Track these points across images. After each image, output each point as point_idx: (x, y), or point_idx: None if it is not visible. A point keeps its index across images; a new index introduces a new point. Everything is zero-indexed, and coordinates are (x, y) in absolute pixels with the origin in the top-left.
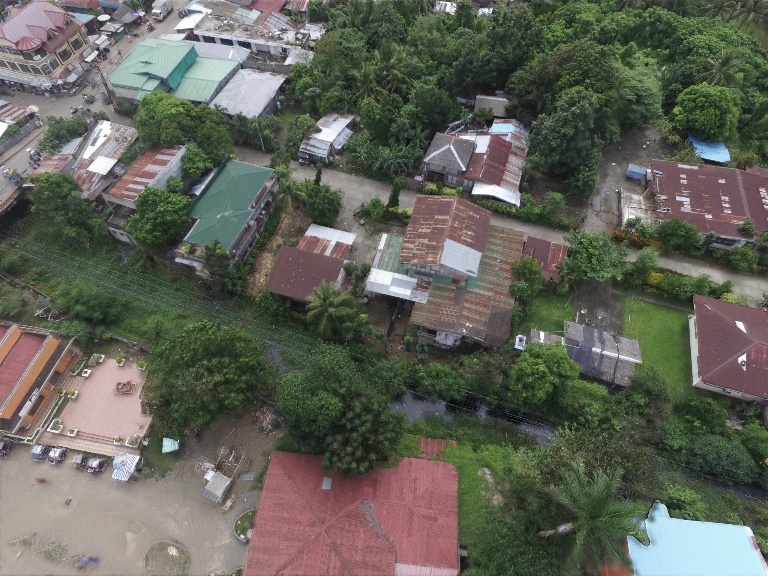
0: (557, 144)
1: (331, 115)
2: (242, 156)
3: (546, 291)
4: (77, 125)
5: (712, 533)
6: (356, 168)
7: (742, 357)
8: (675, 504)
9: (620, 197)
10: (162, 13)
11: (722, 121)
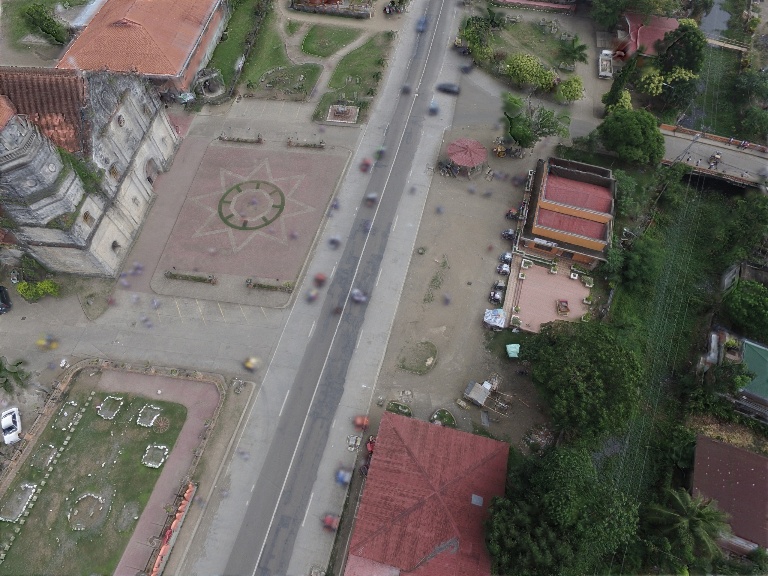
0: None
1: None
2: None
3: None
4: None
5: None
6: None
7: None
8: None
9: None
10: None
11: None
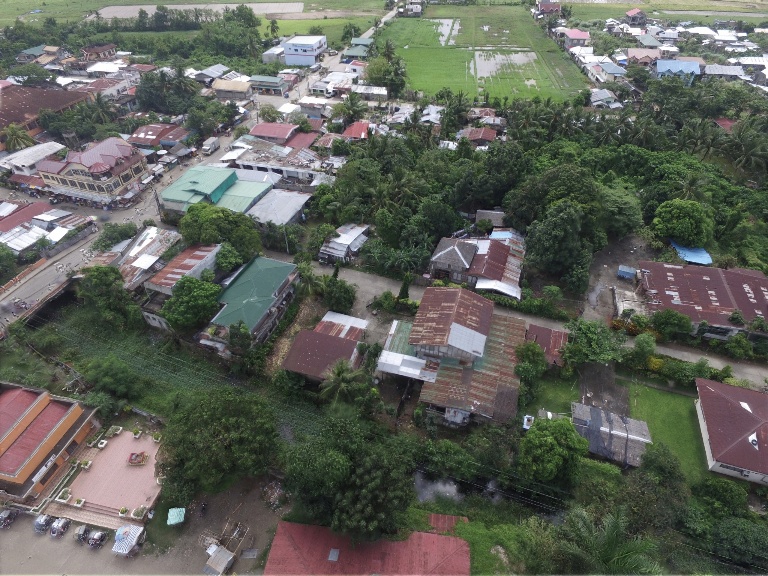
0: (550, 244)
1: (349, 224)
2: (269, 255)
3: (551, 376)
4: (129, 229)
5: None
6: (370, 267)
7: (752, 436)
8: None
9: (614, 293)
10: (210, 149)
11: (698, 229)
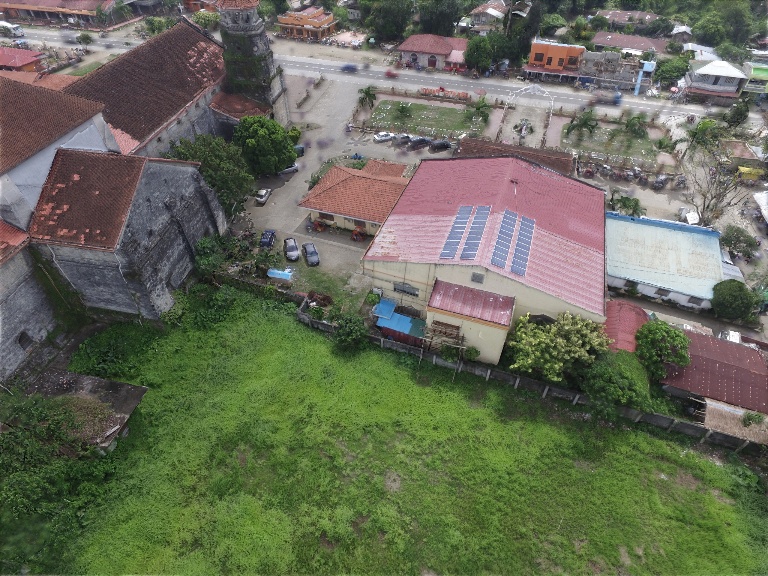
0: None
1: None
2: None
3: None
4: None
5: None
6: None
7: None
8: None
9: None
10: None
11: None
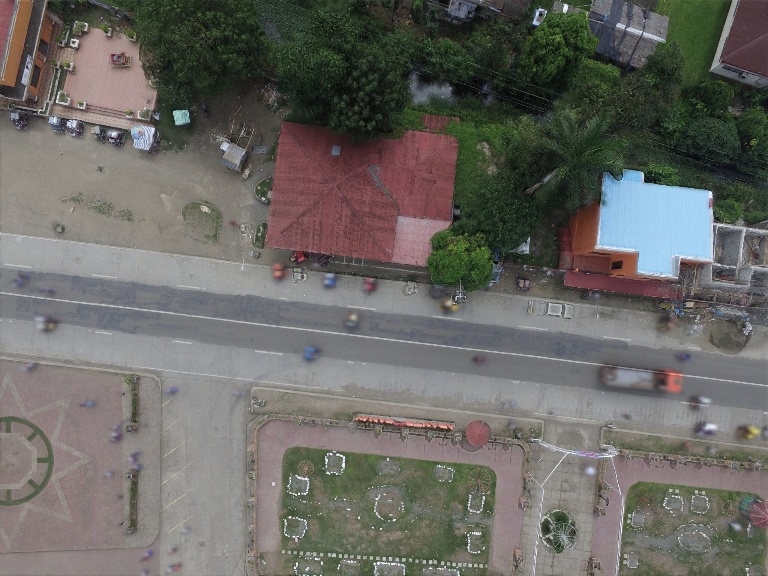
0: None
1: None
2: None
3: None
4: None
5: (677, 195)
6: None
7: None
8: (652, 177)
9: None
10: None
11: None
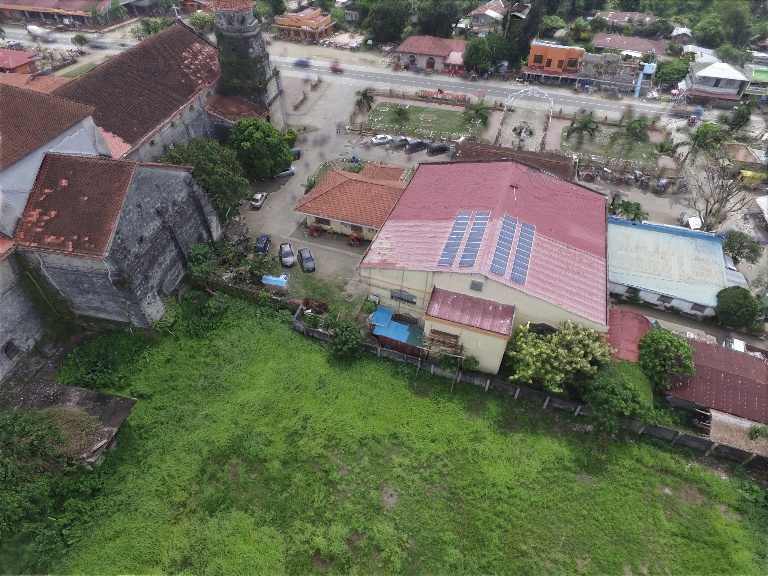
0: None
1: None
2: None
3: None
4: None
5: None
6: None
7: None
8: None
9: None
10: None
11: (637, 1)
